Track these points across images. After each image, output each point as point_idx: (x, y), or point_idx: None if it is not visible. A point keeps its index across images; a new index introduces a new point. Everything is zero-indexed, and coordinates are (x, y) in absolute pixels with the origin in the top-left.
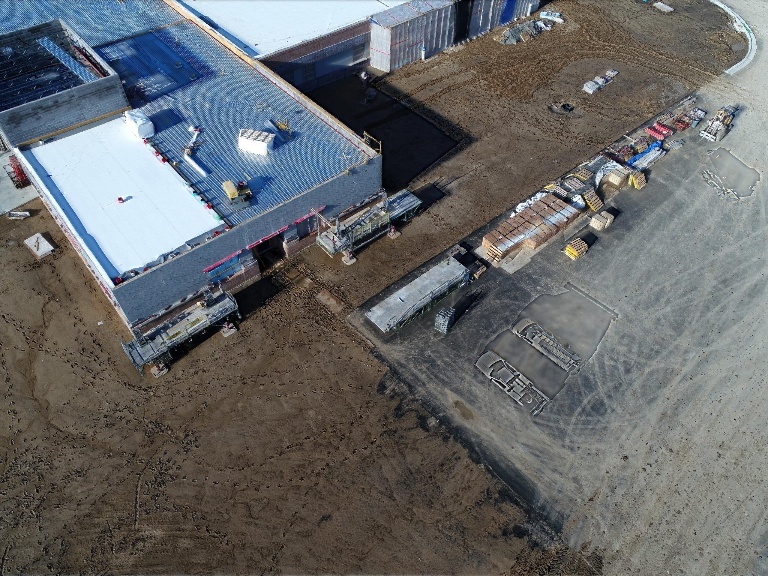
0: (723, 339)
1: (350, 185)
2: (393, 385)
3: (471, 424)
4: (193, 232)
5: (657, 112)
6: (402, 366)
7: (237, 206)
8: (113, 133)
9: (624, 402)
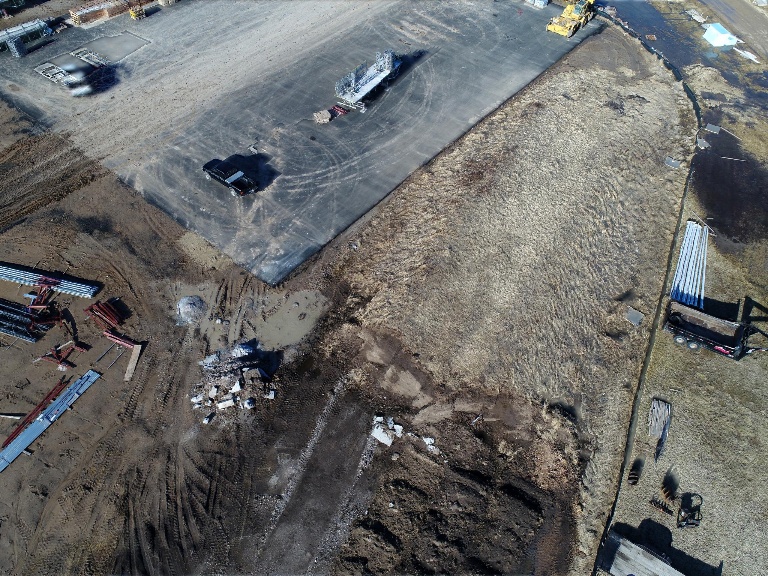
0: (216, 47)
1: None
2: None
3: (16, 93)
4: None
5: None
6: None
7: None
8: None
9: (128, 77)
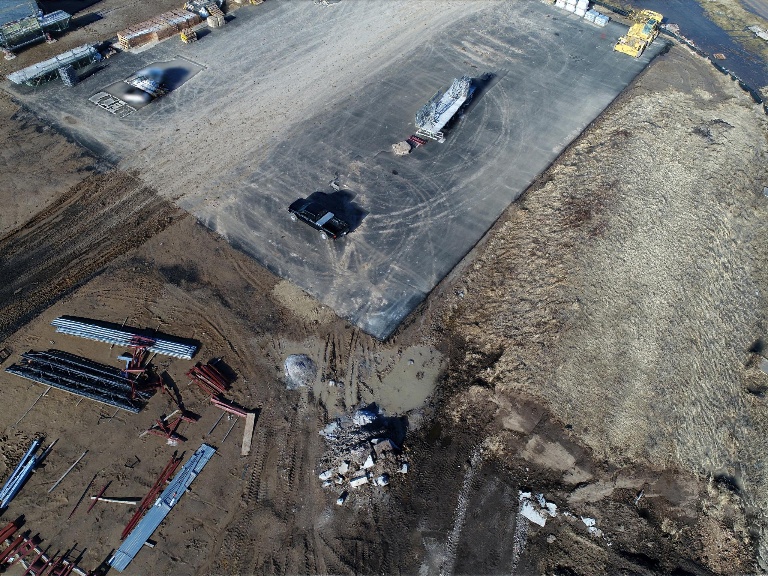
0: (276, 72)
1: None
2: (23, 114)
3: (74, 126)
4: None
5: None
6: (32, 104)
7: None
8: None
9: (190, 106)
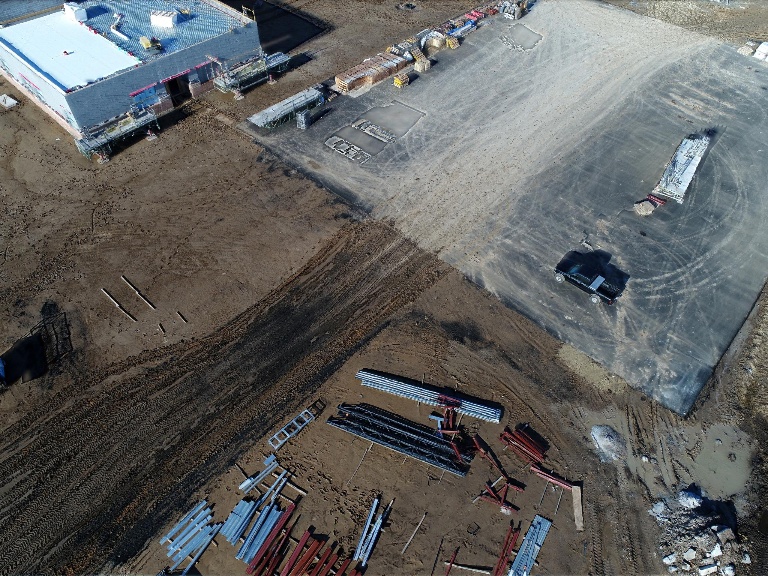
0: (494, 121)
1: (235, 43)
2: (267, 157)
3: (318, 170)
4: (120, 67)
5: (477, 5)
6: (274, 147)
7: (151, 52)
8: (56, 20)
9: (422, 154)
